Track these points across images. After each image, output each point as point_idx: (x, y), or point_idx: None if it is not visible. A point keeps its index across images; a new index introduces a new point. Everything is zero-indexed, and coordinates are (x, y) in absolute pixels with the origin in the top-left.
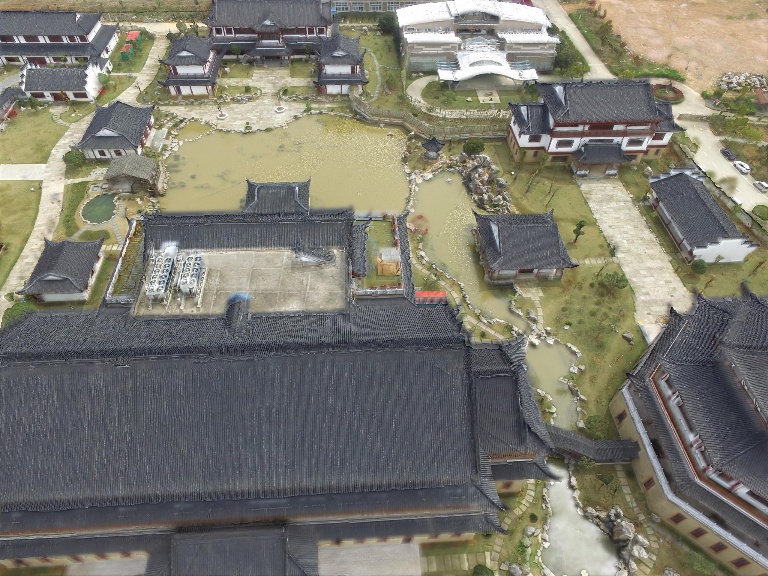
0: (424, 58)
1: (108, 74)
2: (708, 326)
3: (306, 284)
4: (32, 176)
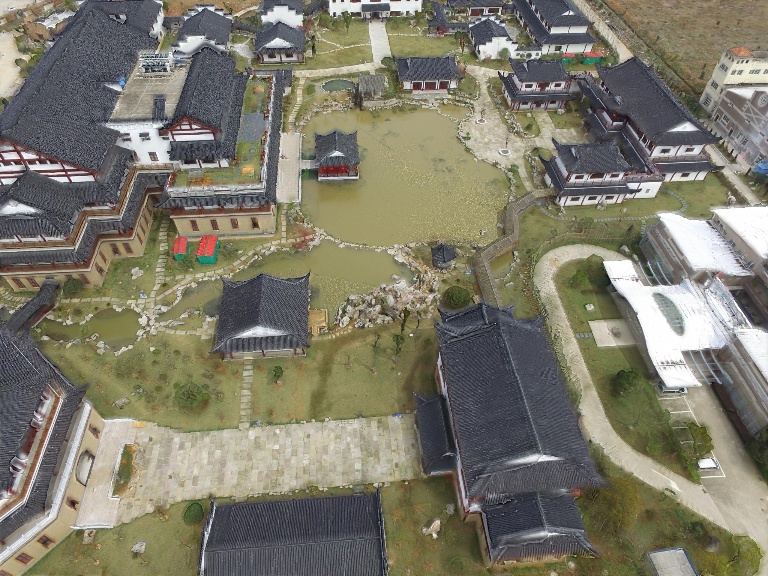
0: (657, 247)
1: (520, 57)
2: (8, 368)
3: (141, 113)
4: (378, 58)
